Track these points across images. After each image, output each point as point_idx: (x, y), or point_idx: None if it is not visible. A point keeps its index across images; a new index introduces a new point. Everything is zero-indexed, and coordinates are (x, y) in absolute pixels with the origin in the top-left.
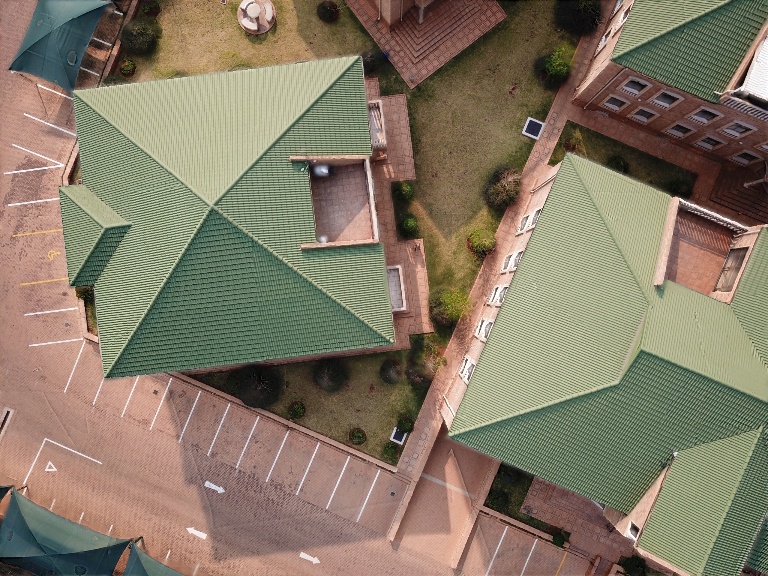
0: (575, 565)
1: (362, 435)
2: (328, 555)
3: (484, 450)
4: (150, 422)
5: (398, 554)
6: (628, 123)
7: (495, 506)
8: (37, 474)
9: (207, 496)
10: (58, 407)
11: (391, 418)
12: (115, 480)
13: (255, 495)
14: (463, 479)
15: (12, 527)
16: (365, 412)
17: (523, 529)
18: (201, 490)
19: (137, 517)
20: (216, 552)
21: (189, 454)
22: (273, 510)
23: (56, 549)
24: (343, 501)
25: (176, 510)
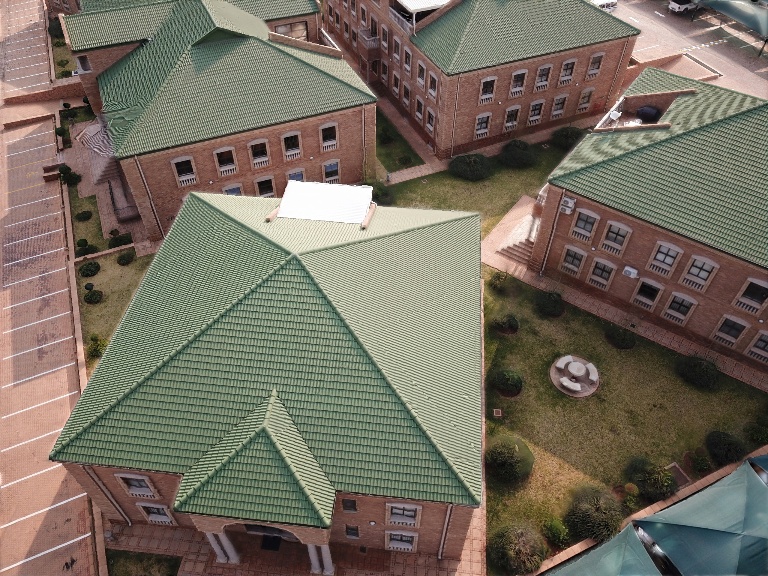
0: None
1: (65, 63)
2: None
3: (82, 3)
4: (11, 26)
5: None
6: (338, 39)
7: (63, 114)
8: None
9: None
10: None
11: None
12: None
13: None
14: None
15: None
16: None
17: None
18: None
19: None
20: None
21: (2, 40)
22: None
23: None
24: None
25: None
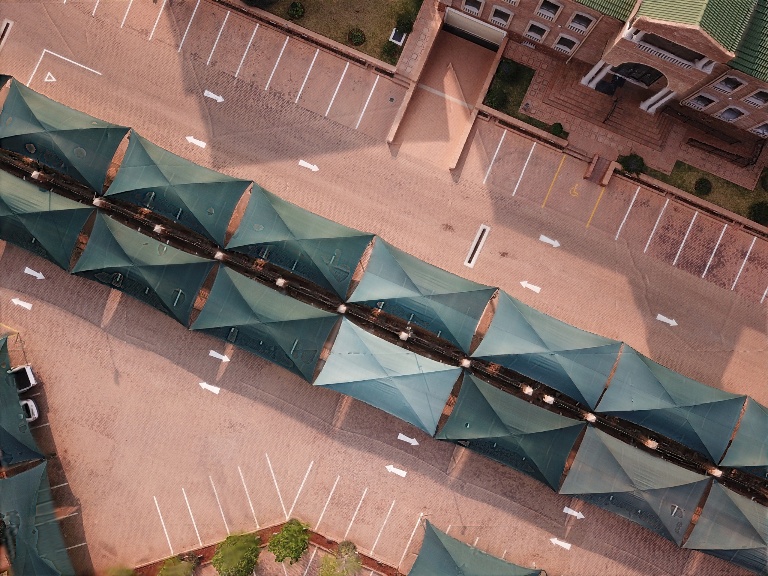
0: (573, 168)
1: (361, 35)
2: (327, 162)
3: None
4: (149, 32)
5: (397, 160)
6: None
7: (494, 104)
8: (36, 84)
9: (206, 105)
10: (57, 18)
11: (390, 19)
12: (114, 90)
13: (254, 103)
14: (462, 91)
15: (11, 112)
16: (364, 13)
17: (522, 131)
18: (200, 99)
19: (136, 126)
20: (215, 160)
21: (188, 64)
22: (272, 118)
23: (55, 125)
24: (342, 108)
25: (175, 120)
